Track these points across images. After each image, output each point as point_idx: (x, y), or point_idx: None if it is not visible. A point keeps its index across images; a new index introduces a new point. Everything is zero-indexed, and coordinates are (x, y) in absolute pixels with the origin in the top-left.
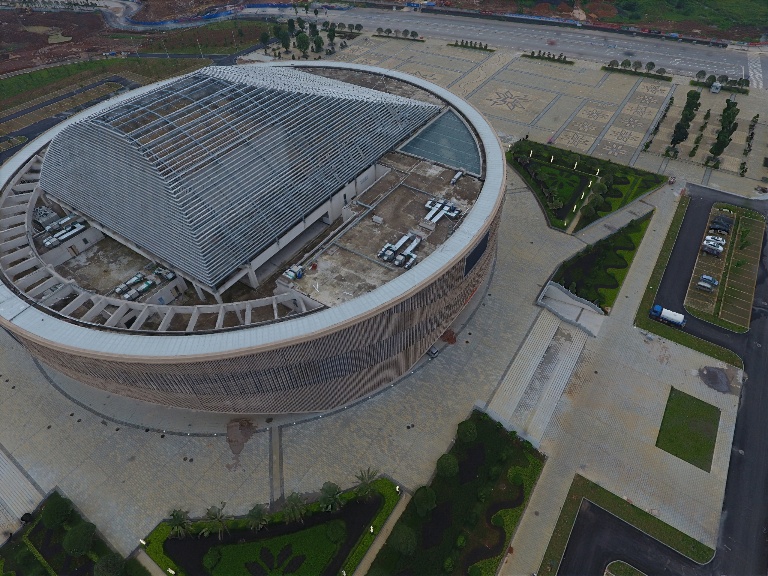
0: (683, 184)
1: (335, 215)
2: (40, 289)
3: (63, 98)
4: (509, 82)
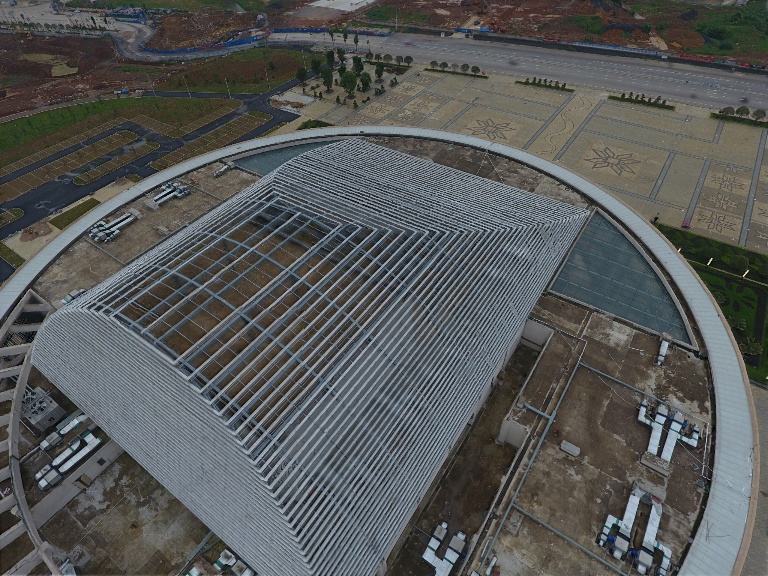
0: None
1: (478, 409)
2: None
3: (68, 153)
4: (604, 134)
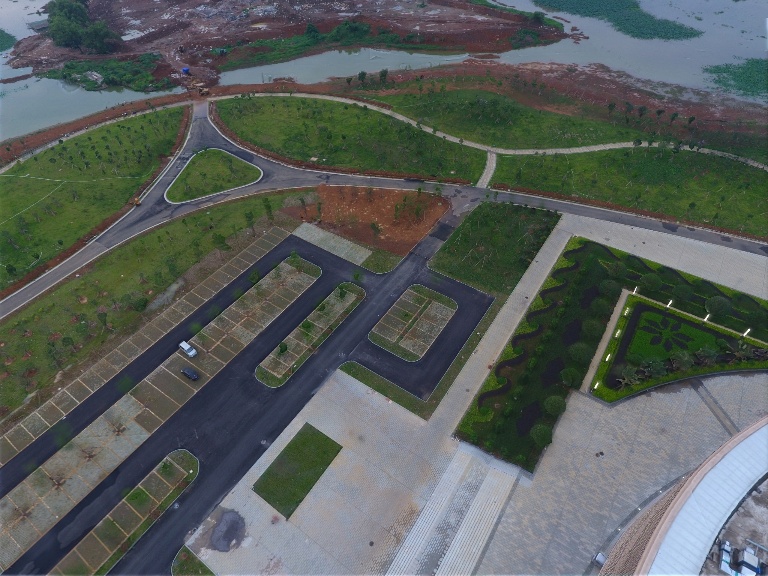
0: None
1: None
2: None
3: None
4: None
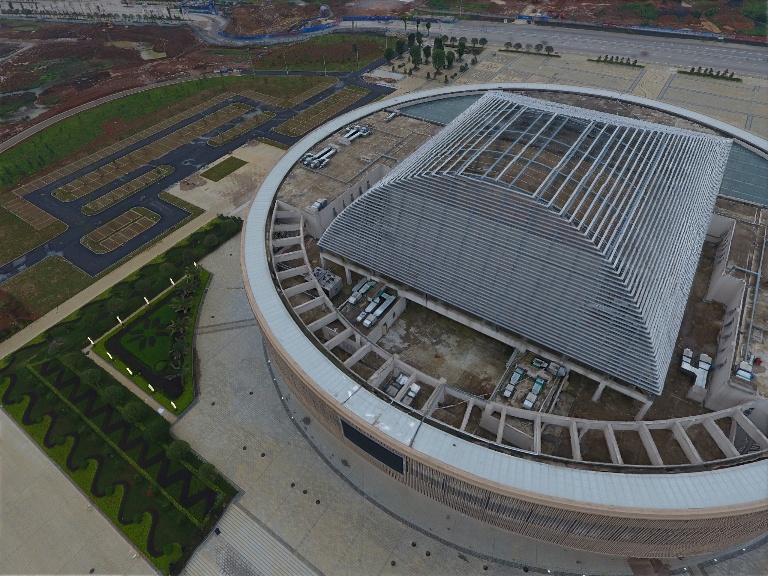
0: None
1: None
2: (404, 392)
3: (193, 121)
4: (683, 102)
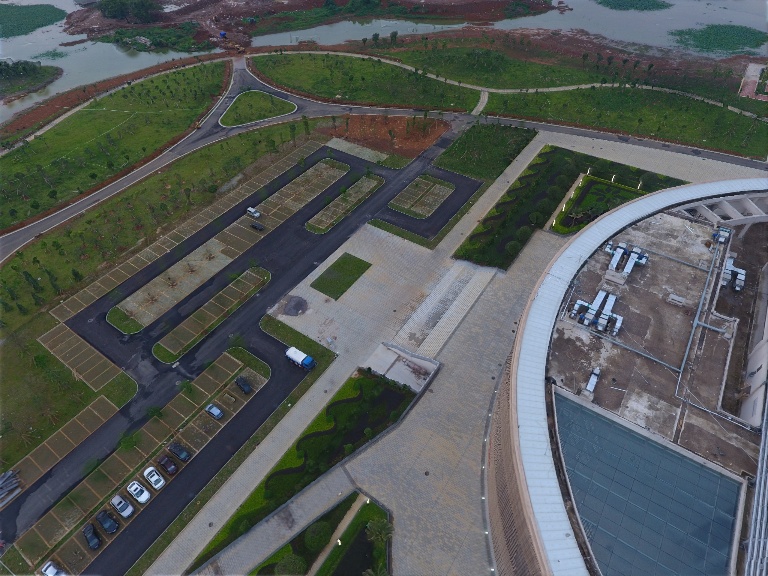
0: None
1: None
2: None
3: None
4: None
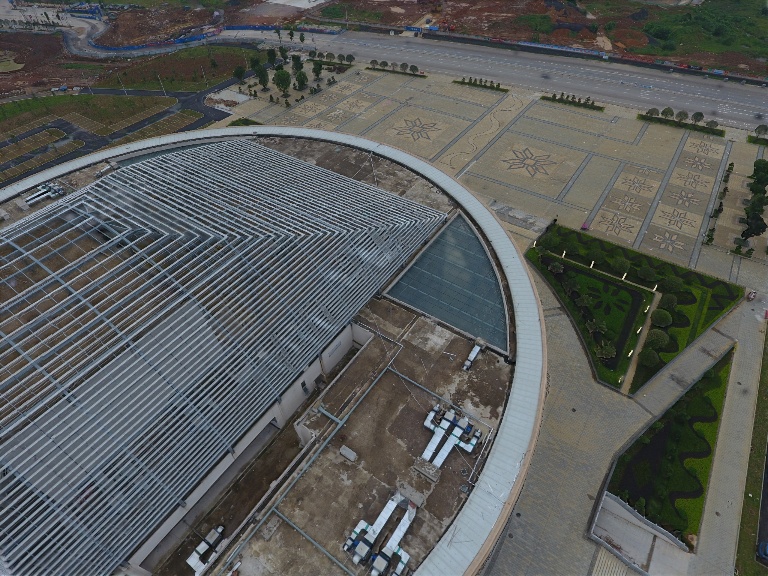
0: (766, 301)
1: (288, 413)
2: None
3: None
4: (527, 135)
